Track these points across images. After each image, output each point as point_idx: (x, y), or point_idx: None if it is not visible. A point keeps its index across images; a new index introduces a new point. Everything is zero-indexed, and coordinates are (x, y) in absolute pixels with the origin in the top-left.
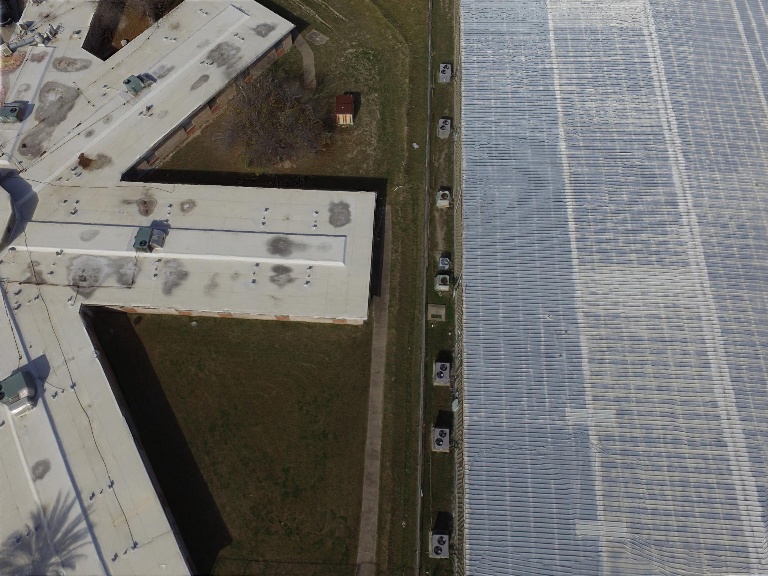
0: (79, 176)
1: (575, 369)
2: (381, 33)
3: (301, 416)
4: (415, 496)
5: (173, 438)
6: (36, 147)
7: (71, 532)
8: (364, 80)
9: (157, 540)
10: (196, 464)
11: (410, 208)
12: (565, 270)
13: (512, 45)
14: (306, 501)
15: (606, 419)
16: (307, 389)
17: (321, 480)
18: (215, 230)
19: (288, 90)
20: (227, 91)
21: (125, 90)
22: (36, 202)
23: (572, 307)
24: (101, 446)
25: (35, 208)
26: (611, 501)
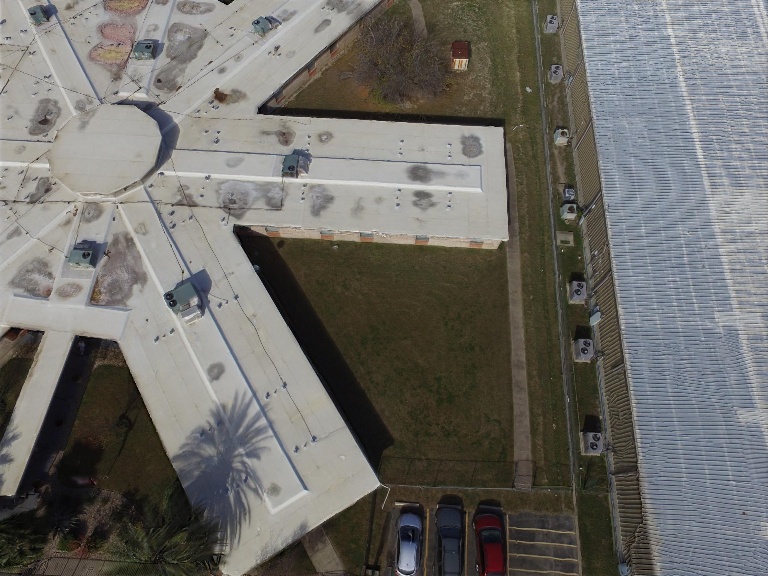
0: (217, 109)
1: (718, 278)
2: None
3: (447, 330)
4: (562, 401)
5: (327, 350)
6: (171, 82)
7: (252, 427)
8: (472, 30)
9: (334, 434)
10: (352, 373)
11: (529, 146)
12: (699, 192)
13: None
14: (460, 406)
15: (753, 320)
16: (450, 306)
17: (472, 387)
18: (355, 159)
19: None
20: (346, 36)
21: (252, 31)
22: (178, 132)
23: (709, 224)
24: (270, 351)
25: (178, 137)
26: (765, 391)
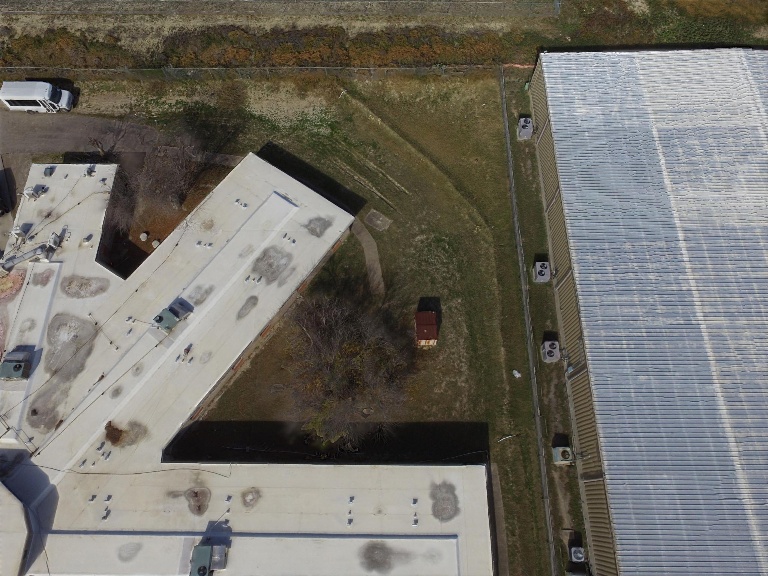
0: (108, 458)
1: None
2: (454, 211)
3: None
4: None
5: None
6: (49, 414)
7: None
8: (442, 279)
9: None
10: None
11: (521, 466)
12: None
13: (635, 255)
14: None
15: None
16: None
17: None
18: (290, 535)
19: (360, 319)
20: None
21: (155, 325)
22: (56, 500)
23: None
24: None
25: (55, 510)
26: None
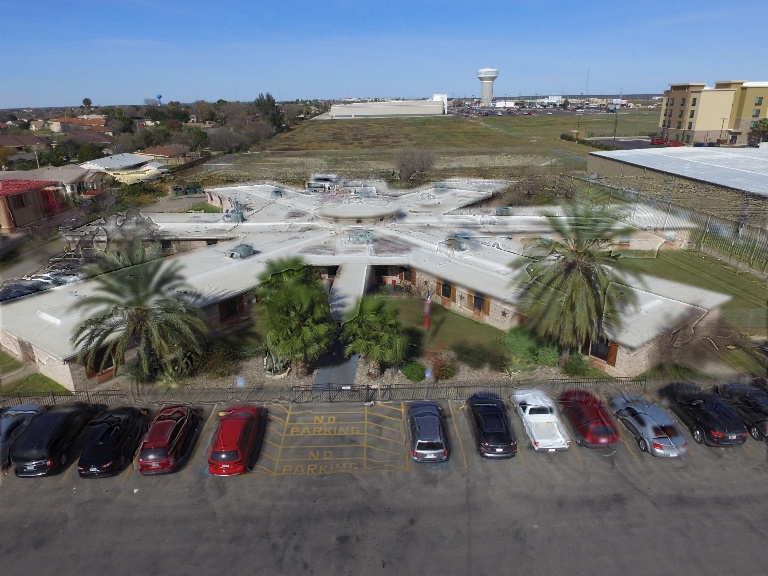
0: (415, 213)
1: None
2: None
3: None
4: None
5: None
6: None
7: None
8: None
9: None
10: None
11: None
12: None
13: None
14: None
15: None
16: None
17: None
18: None
19: None
20: (475, 208)
21: None
22: None
23: None
24: None
25: None
26: None
